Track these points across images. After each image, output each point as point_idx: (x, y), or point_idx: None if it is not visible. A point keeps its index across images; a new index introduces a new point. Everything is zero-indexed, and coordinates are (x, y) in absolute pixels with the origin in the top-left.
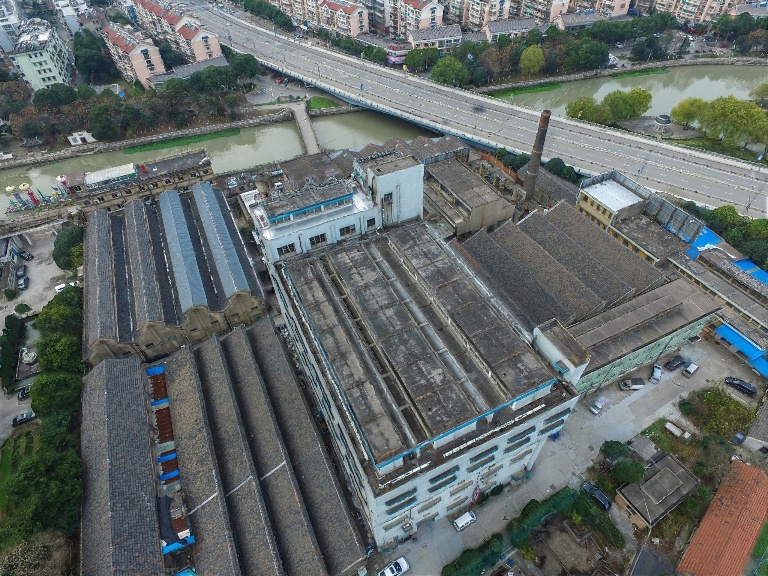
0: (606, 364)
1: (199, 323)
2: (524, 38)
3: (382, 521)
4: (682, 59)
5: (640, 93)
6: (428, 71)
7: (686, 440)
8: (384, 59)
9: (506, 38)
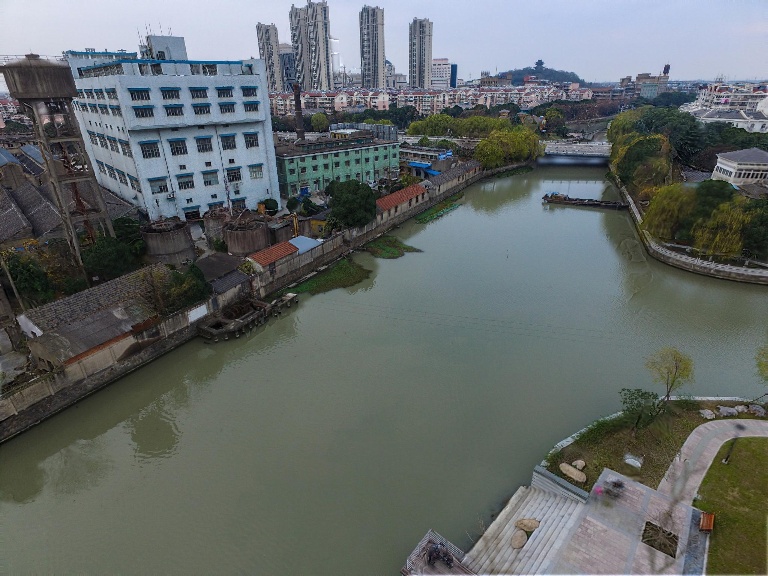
0: (323, 152)
1: (14, 182)
2: None
3: (133, 125)
4: None
5: None
6: None
7: (383, 192)
8: None
9: None
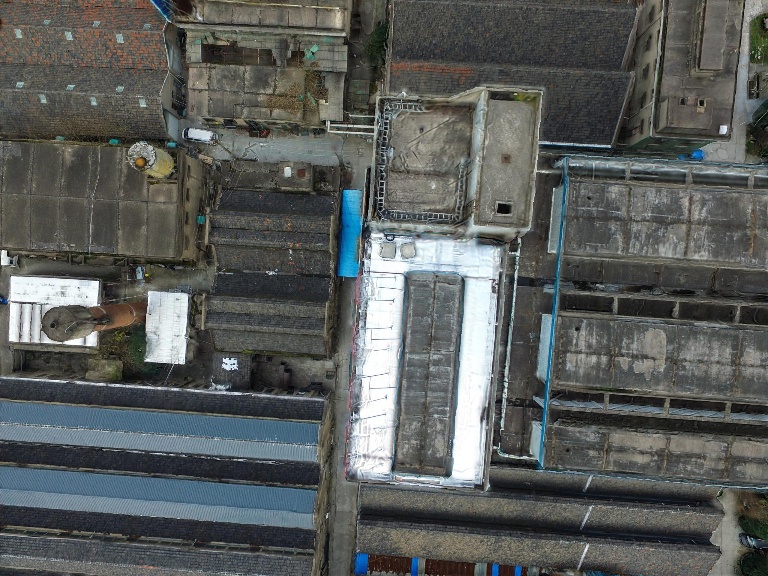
0: (740, 40)
1: None
2: None
3: None
4: None
5: None
6: None
7: None
8: None
9: None
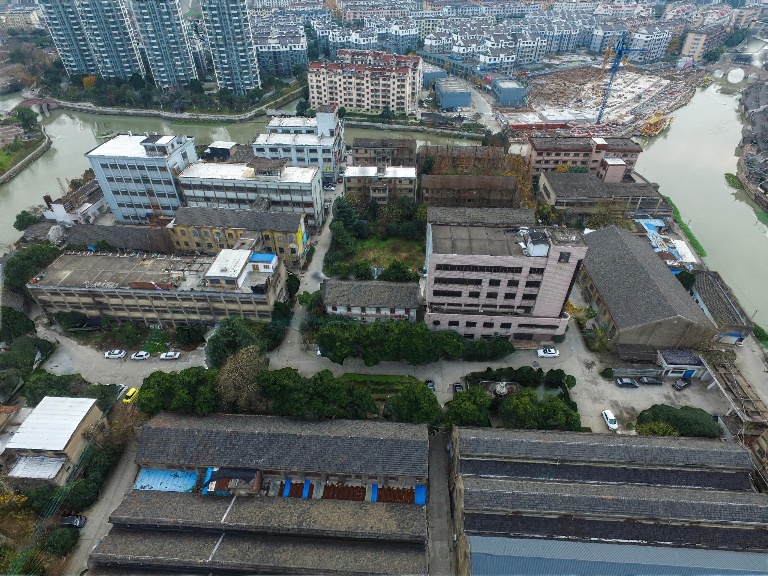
0: None
1: None
2: None
3: None
4: None
5: None
6: None
7: None
8: None
9: None
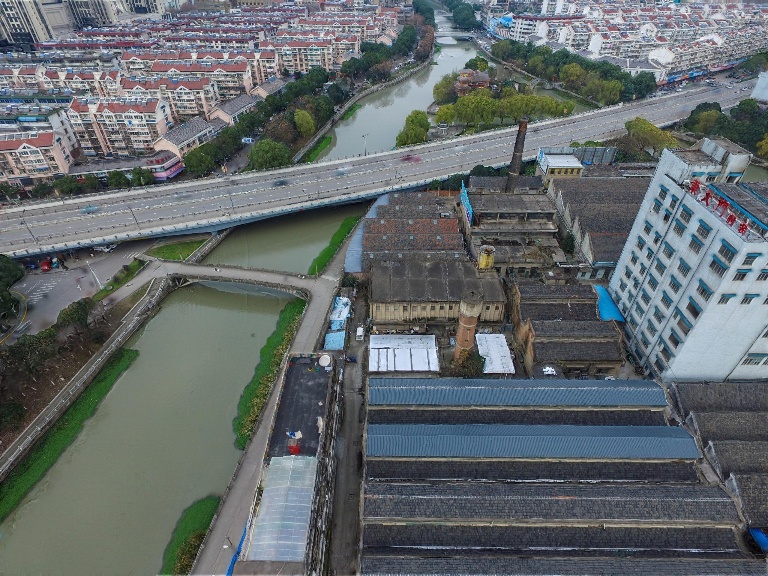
0: None
1: None
2: (253, 112)
3: None
4: (355, 95)
5: (421, 113)
6: (213, 171)
7: None
8: (153, 178)
9: (252, 115)
